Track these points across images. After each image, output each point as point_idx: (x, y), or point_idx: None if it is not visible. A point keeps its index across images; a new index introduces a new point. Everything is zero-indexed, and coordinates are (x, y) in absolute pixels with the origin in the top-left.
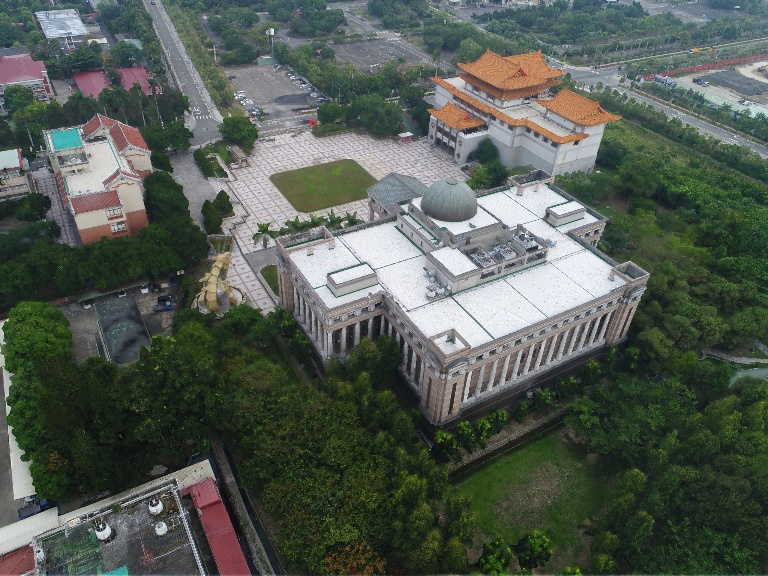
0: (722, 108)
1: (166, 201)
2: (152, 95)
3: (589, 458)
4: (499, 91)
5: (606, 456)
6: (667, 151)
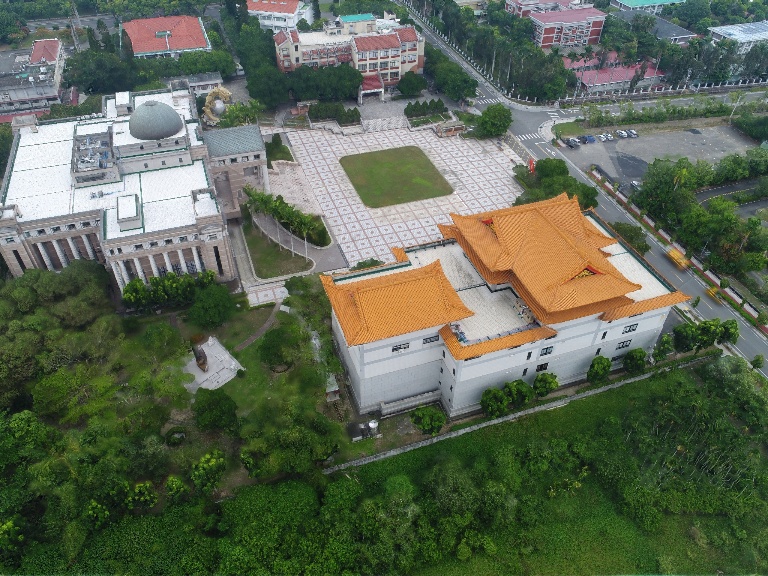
0: None
1: None
2: None
3: None
4: None
5: None
6: None
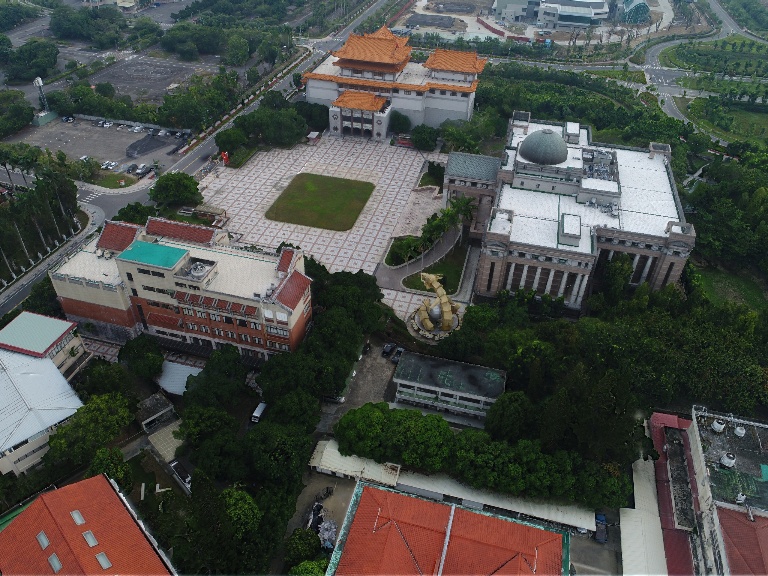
0: (458, 41)
1: (309, 264)
2: (1, 197)
3: (720, 269)
4: (389, 67)
5: (738, 259)
6: None
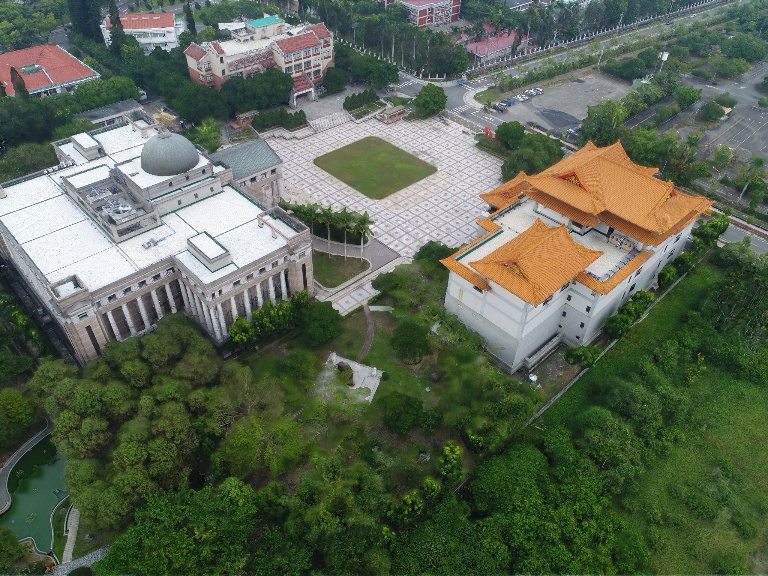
0: None
1: (232, 80)
2: (471, 54)
3: None
4: None
5: None
6: (765, 523)
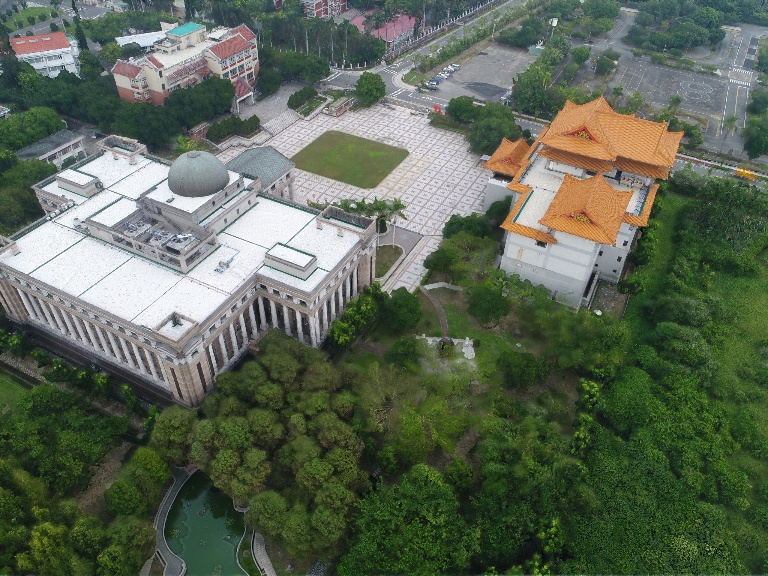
0: None
1: (176, 94)
2: None
3: None
4: None
5: None
6: None
